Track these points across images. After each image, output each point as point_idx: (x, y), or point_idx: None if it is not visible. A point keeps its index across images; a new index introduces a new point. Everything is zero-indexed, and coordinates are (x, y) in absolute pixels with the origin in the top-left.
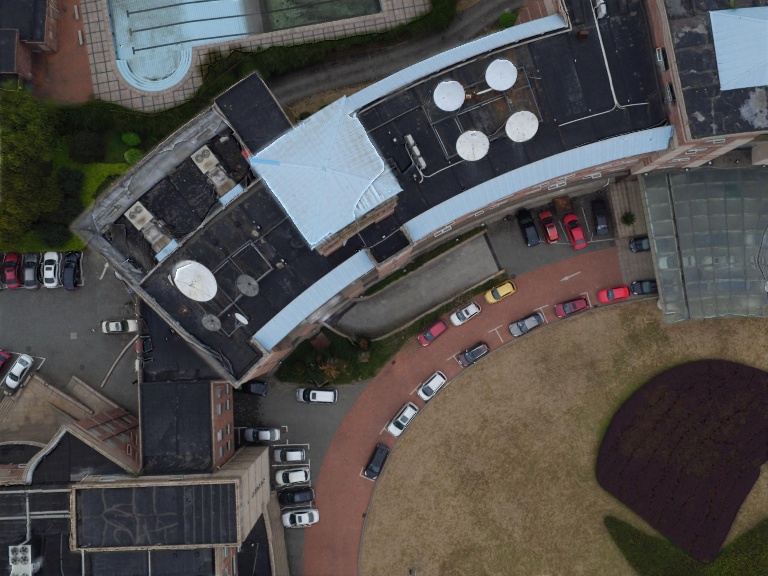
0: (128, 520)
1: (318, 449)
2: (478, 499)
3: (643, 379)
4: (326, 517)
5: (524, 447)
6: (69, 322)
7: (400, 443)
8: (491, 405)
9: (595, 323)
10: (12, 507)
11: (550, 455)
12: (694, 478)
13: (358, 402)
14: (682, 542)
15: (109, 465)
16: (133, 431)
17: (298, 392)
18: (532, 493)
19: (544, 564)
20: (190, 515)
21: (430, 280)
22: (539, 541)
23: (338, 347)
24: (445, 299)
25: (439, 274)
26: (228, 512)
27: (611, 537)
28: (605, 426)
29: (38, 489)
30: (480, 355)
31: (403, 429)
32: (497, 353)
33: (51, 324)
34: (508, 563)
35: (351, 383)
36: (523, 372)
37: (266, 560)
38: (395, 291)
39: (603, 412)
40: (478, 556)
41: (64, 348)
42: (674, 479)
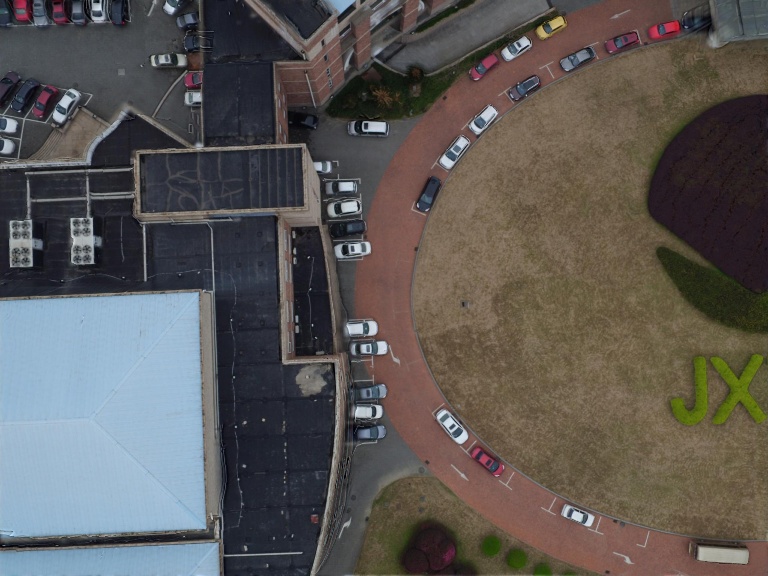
0: (193, 186)
1: (369, 183)
2: (530, 232)
3: (694, 115)
4: (378, 251)
5: (576, 181)
6: (116, 58)
7: (452, 177)
8: (542, 140)
9: (645, 59)
10: (71, 191)
11: (602, 189)
12: (746, 208)
13: (409, 137)
14: (735, 271)
15: (170, 144)
16: (194, 111)
17: (349, 125)
18: (584, 226)
19: (597, 296)
20: (256, 181)
21: (480, 20)
22: (592, 273)
23: (389, 81)
24: (495, 37)
25: (489, 14)
26: (294, 177)
27: (664, 268)
28: (656, 160)
29: (98, 169)
30: (532, 87)
31: (455, 162)
32: (548, 89)
33: (98, 60)
34: (561, 295)
35: (402, 118)
36: (574, 107)
37: (322, 273)
38: (444, 32)
39: (654, 147)
40: (531, 288)
41: (112, 84)
42: (726, 209)
